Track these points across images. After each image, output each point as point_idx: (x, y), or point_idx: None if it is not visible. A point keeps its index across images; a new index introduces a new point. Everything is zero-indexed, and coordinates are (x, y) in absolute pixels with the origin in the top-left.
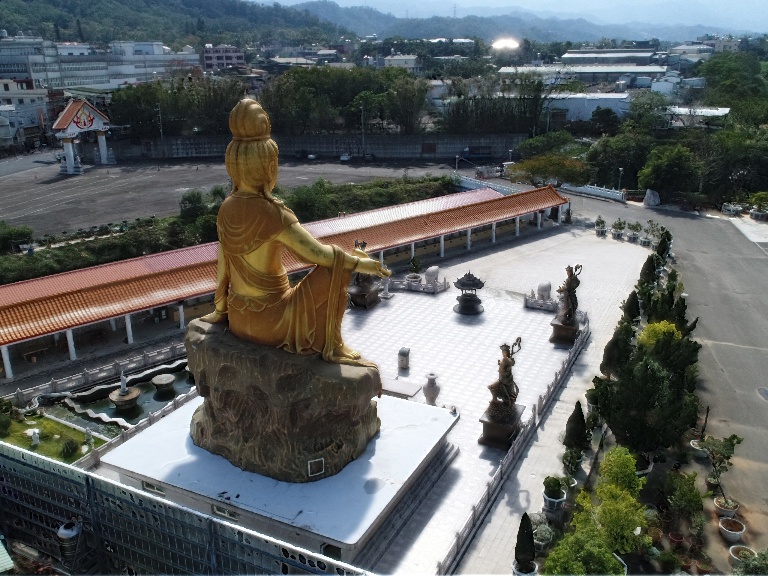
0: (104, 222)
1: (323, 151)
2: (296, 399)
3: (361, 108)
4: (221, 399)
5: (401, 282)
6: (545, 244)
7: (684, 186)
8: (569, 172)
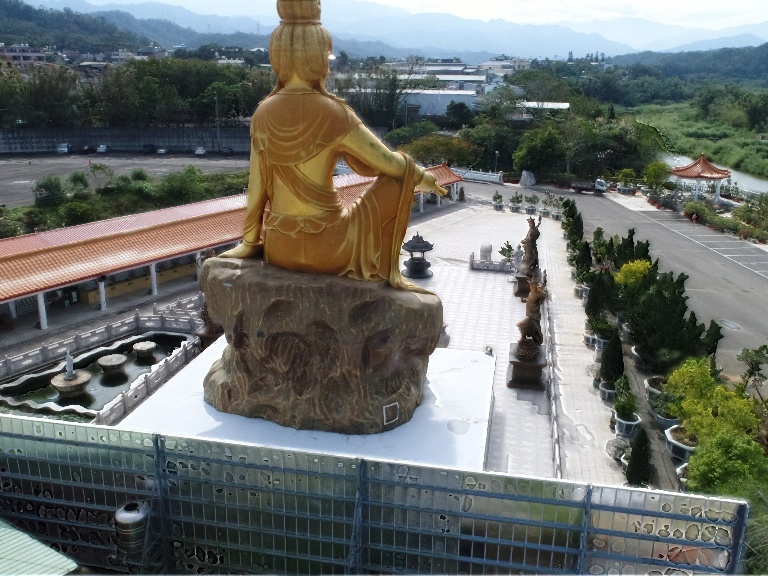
0: None
1: (173, 146)
2: (373, 332)
3: (215, 99)
4: (266, 346)
5: None
6: (452, 218)
7: (554, 167)
8: (459, 151)
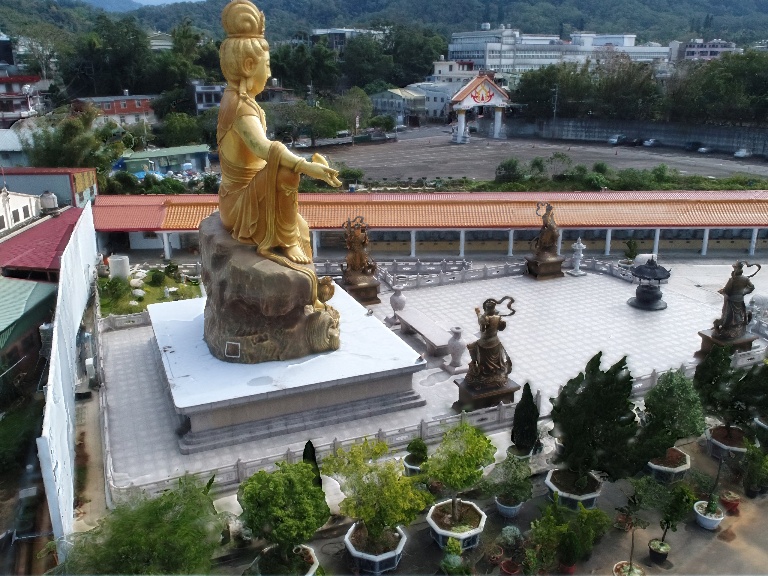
0: (430, 178)
1: (721, 145)
2: (219, 278)
3: None
4: (204, 273)
5: (604, 263)
6: None
7: None
8: None
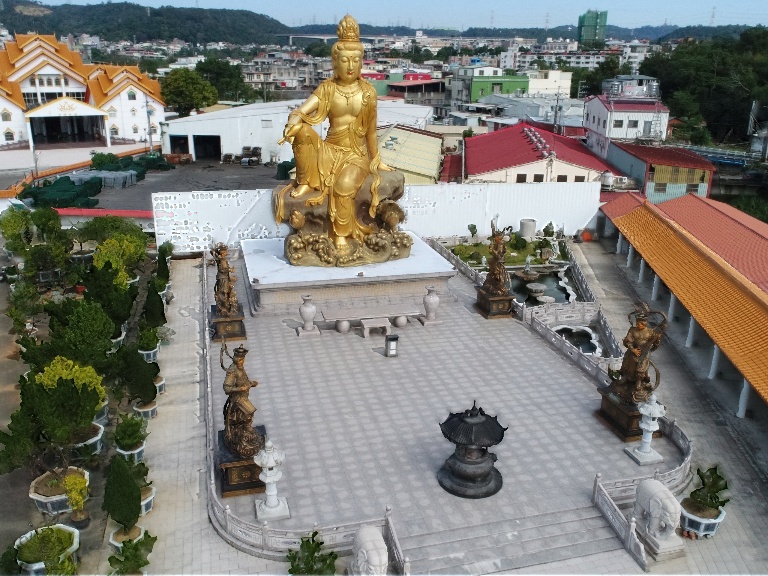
0: None
1: None
2: None
3: None
4: None
5: (672, 472)
6: None
7: None
8: None
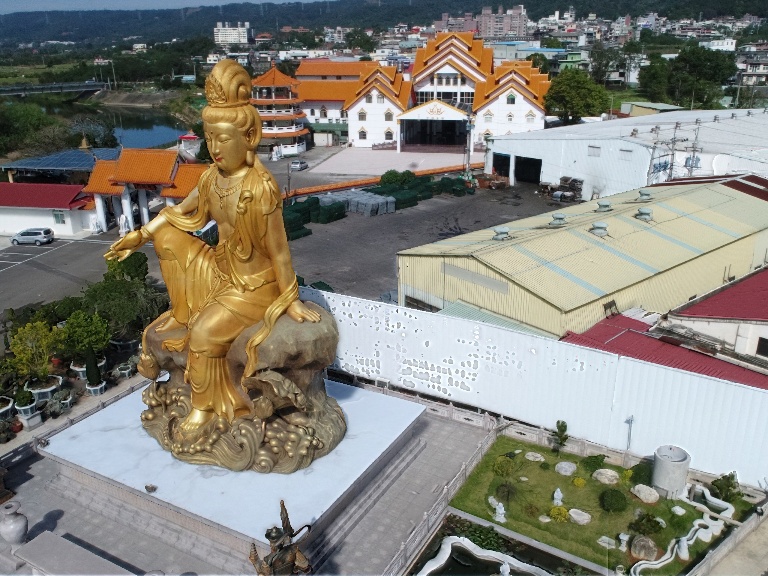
0: None
1: None
2: None
3: None
4: None
5: None
6: None
7: None
8: None
